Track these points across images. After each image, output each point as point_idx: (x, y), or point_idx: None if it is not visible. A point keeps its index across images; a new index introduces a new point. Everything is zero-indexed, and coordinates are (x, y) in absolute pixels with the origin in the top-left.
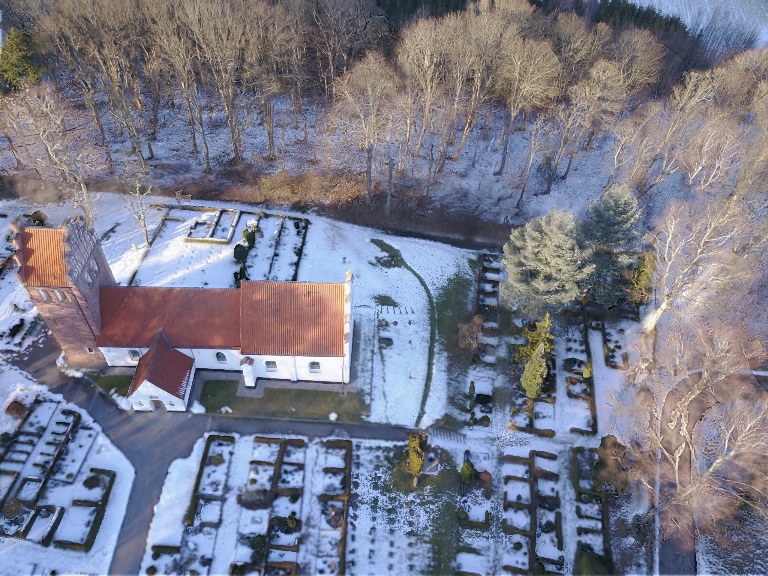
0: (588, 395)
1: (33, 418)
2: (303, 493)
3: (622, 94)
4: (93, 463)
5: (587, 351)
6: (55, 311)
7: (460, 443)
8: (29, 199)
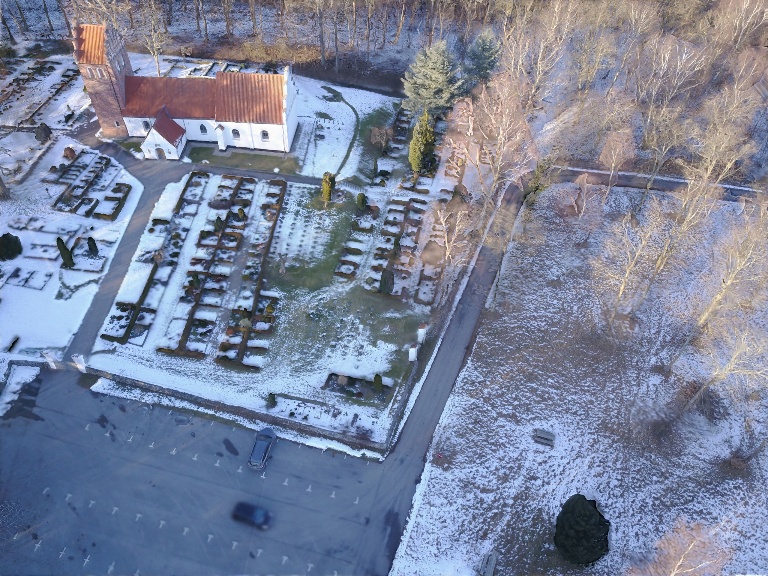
0: (459, 175)
1: (80, 160)
2: (251, 205)
3: None
4: (118, 182)
5: None
6: (96, 87)
7: (362, 192)
8: None
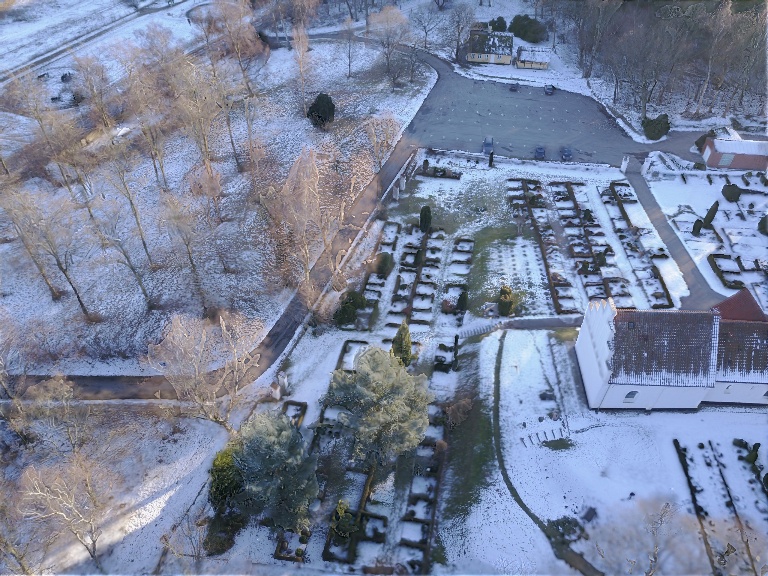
0: None
1: None
2: None
3: None
4: None
5: (323, 417)
6: None
7: (466, 331)
8: None
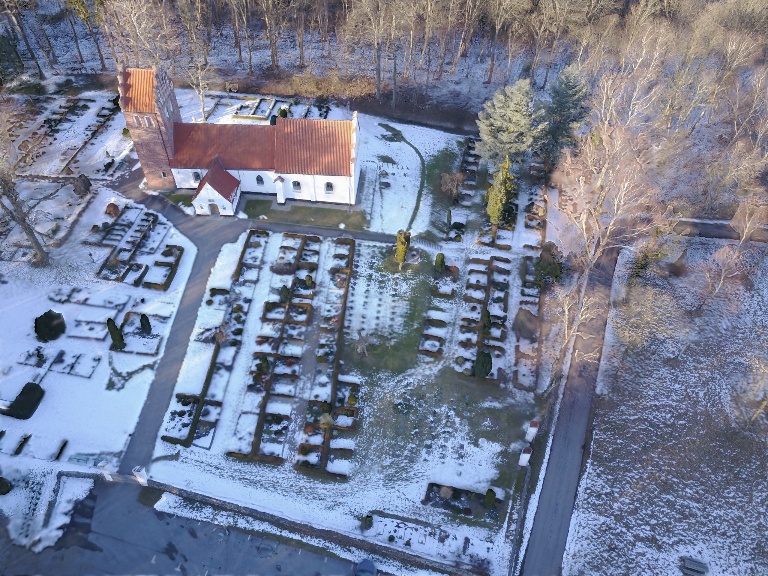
0: (541, 227)
1: (124, 217)
2: (317, 268)
3: (585, 7)
4: (168, 243)
5: (544, 200)
6: (143, 136)
7: (437, 250)
8: (112, 90)
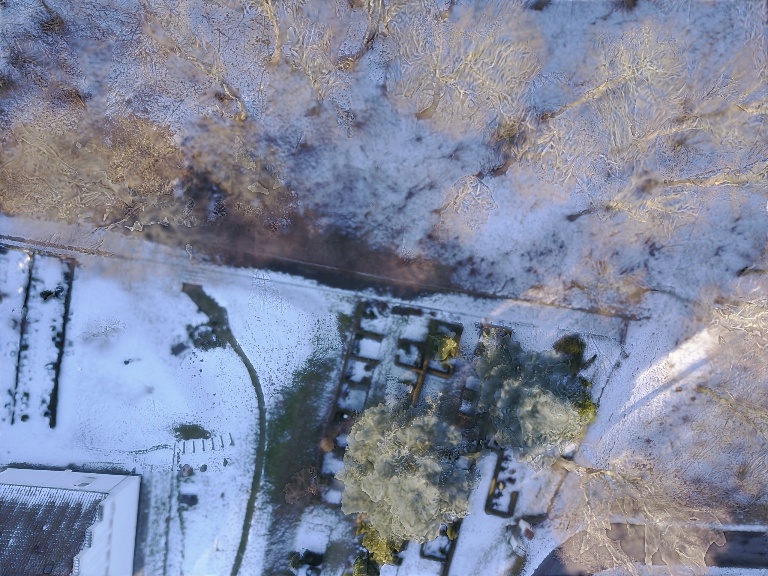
0: (445, 554)
1: None
2: None
3: (675, 108)
4: None
5: None
6: None
7: None
8: None
